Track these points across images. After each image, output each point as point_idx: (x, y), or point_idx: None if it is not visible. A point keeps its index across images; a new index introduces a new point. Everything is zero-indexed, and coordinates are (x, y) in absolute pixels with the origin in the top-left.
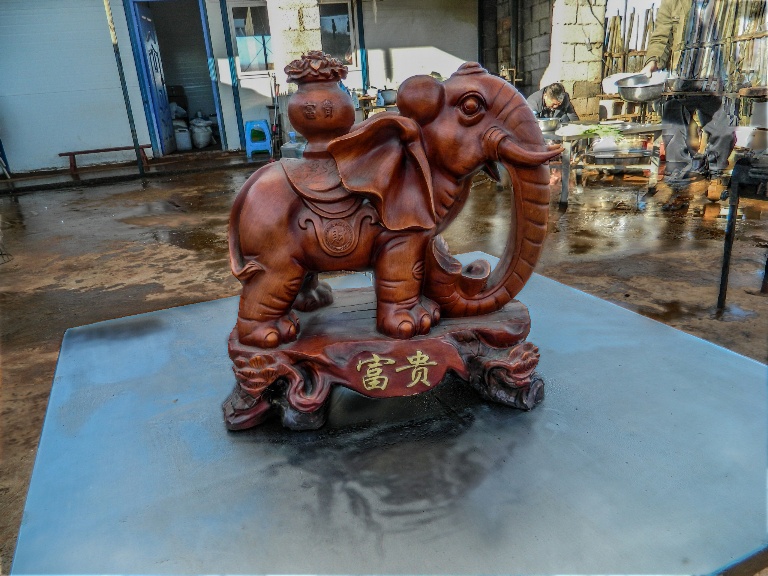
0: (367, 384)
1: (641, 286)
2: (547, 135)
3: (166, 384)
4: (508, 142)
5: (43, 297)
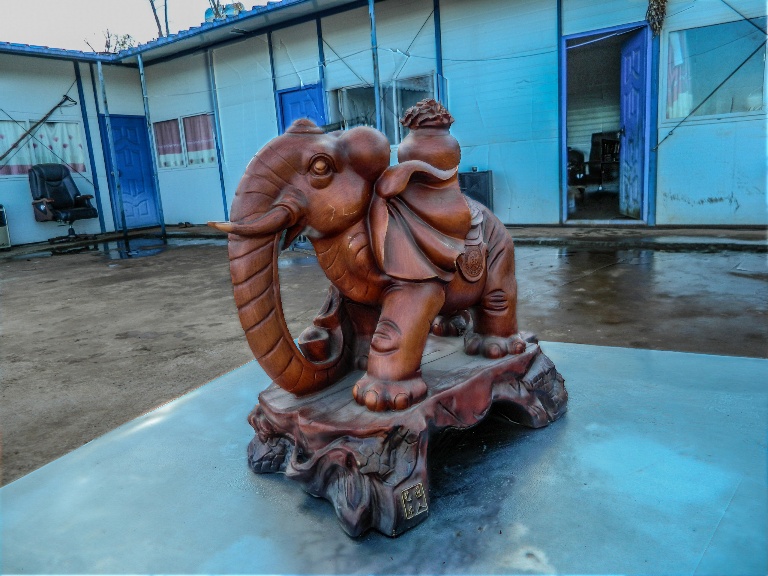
0: None
1: None
2: None
3: (557, 368)
4: None
5: None
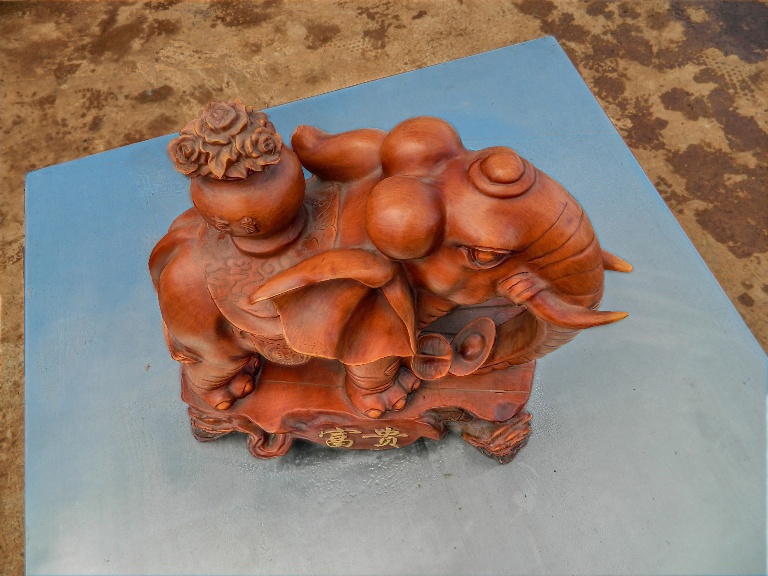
0: (331, 444)
1: None
2: None
3: (137, 332)
4: (537, 303)
5: None
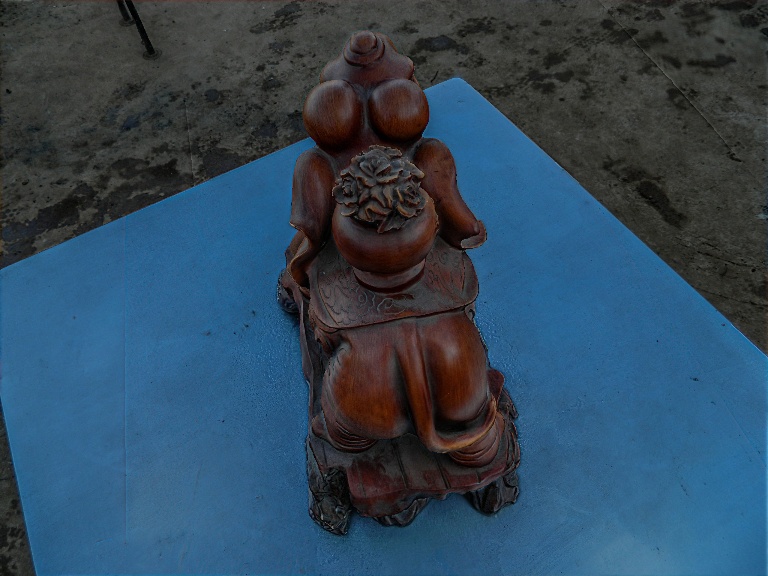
0: None
1: None
2: None
3: None
4: None
5: None
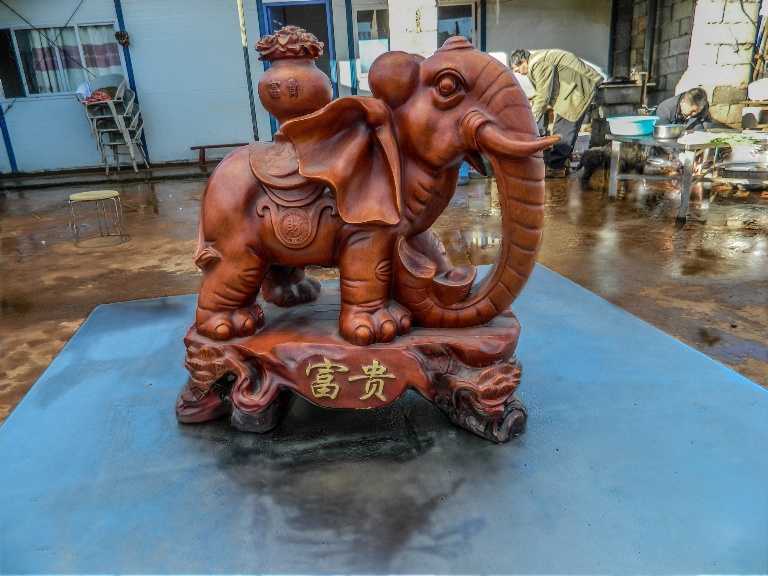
0: (316, 391)
1: (754, 317)
2: (668, 143)
3: (150, 367)
4: (488, 129)
5: (144, 276)
